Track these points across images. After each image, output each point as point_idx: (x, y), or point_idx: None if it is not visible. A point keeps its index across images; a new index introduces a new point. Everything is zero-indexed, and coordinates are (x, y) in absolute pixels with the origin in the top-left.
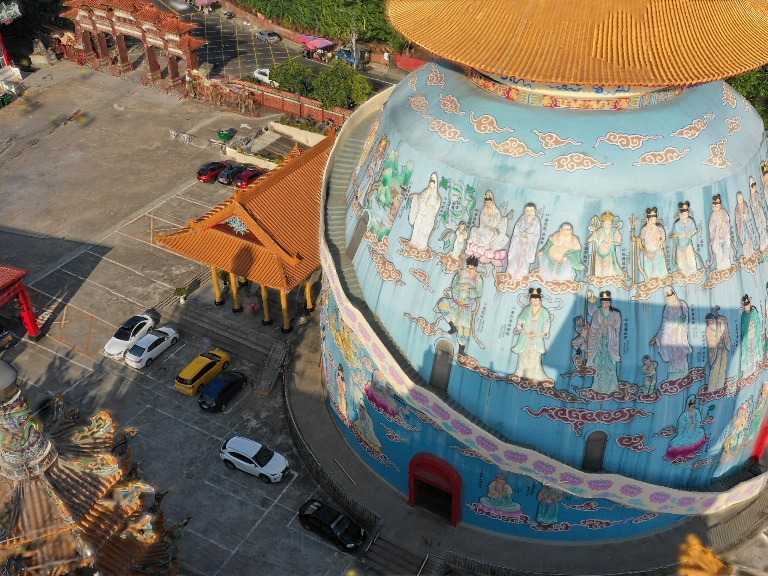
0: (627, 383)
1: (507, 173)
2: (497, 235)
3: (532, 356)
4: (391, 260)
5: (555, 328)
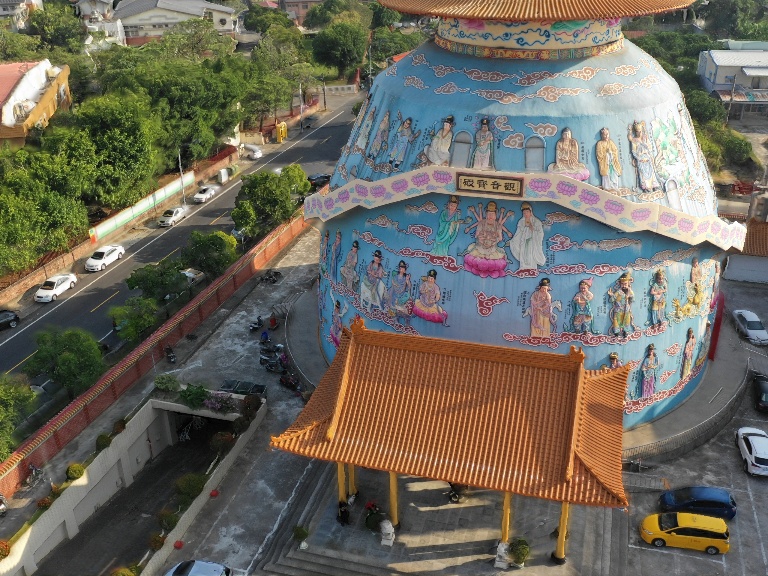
0: None
1: None
2: None
3: None
4: None
5: None
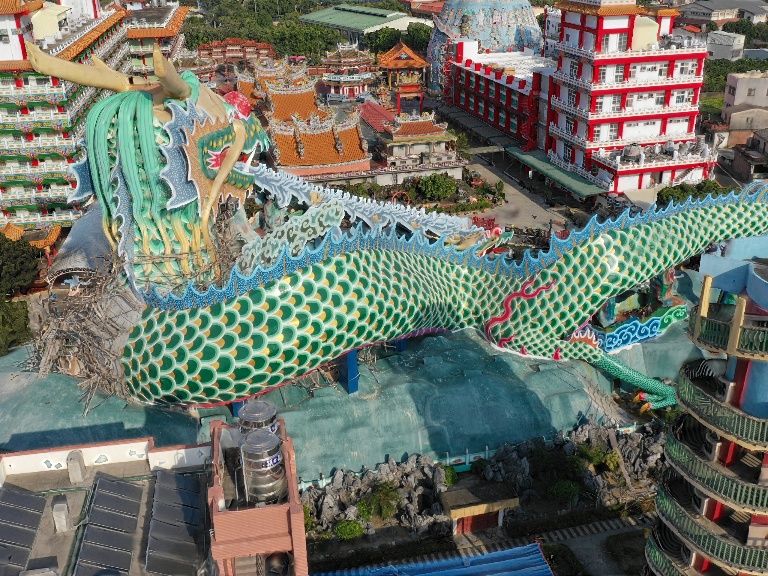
0: (529, 43)
1: (496, 4)
2: (499, 16)
3: (513, 39)
4: (475, 30)
5: (515, 32)
